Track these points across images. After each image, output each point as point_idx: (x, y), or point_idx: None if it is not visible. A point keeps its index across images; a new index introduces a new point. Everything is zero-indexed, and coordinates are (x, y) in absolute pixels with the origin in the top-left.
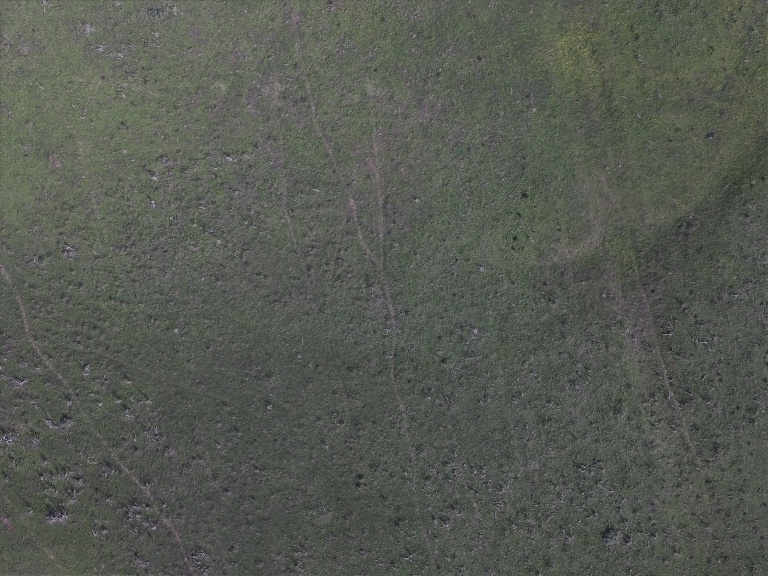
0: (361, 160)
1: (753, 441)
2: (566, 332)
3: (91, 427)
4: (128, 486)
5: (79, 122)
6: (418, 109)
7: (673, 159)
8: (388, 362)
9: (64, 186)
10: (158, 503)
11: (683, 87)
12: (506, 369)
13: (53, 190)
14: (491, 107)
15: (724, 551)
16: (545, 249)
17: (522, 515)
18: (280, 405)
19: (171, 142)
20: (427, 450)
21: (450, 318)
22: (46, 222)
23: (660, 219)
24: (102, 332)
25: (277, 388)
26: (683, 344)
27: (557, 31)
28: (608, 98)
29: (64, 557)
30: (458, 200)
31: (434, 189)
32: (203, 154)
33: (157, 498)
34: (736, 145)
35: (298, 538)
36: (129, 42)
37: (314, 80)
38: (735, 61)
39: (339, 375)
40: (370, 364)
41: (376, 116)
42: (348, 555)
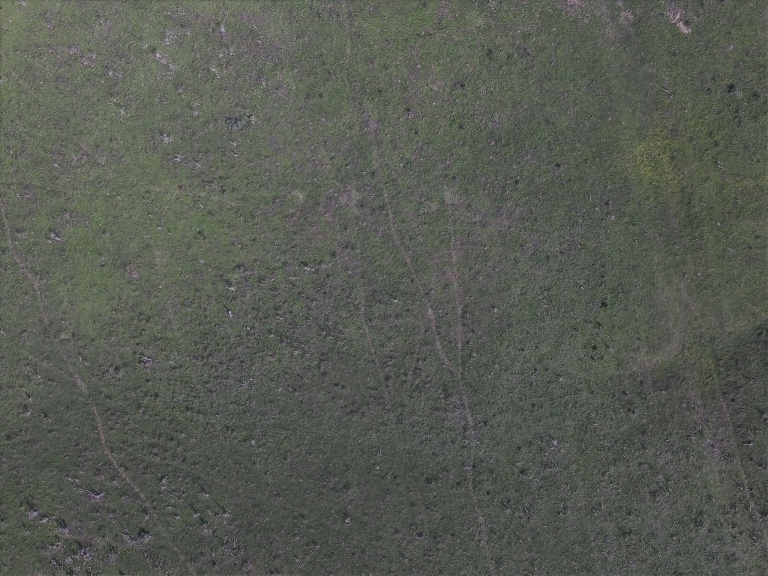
0: (439, 269)
1: None
2: (646, 442)
3: (169, 541)
4: None
5: (156, 232)
6: (496, 217)
7: (753, 266)
8: (467, 473)
9: (141, 296)
10: None
11: (763, 193)
12: (586, 480)
13: (130, 300)
14: (570, 214)
15: None
16: (624, 358)
17: None
18: (358, 517)
19: (248, 251)
20: (507, 563)
21: (529, 428)
22: (123, 332)
23: (740, 327)
24: (179, 443)
25: (355, 500)
26: (764, 454)
27: (635, 137)
28: (687, 205)
29: None
30: (537, 309)
31: (512, 298)
32: (280, 263)
33: None
34: None
35: None
36: (207, 152)
37: (392, 188)
38: None
39: (417, 486)
40: (449, 475)
41: (454, 224)
42: None
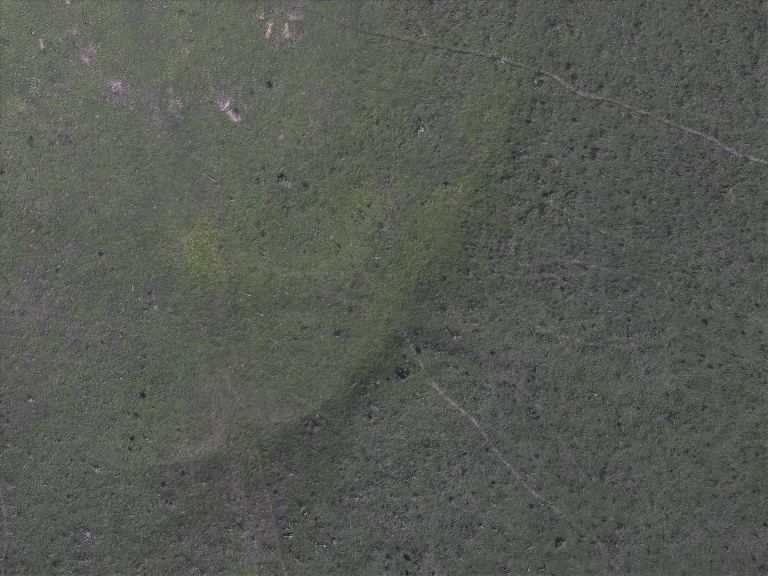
0: None
1: None
2: (182, 535)
3: None
4: None
5: None
6: (35, 306)
7: (299, 357)
8: None
9: None
10: None
11: (310, 284)
12: (119, 572)
13: None
14: (111, 304)
15: None
16: (165, 449)
17: None
18: None
19: None
20: None
21: (63, 520)
22: None
23: (286, 418)
24: None
25: None
26: (302, 547)
27: (183, 226)
28: (233, 295)
29: None
30: (75, 399)
31: (50, 388)
32: None
33: None
34: (365, 343)
35: None
36: None
37: None
38: (364, 258)
39: None
40: None
41: None
42: None
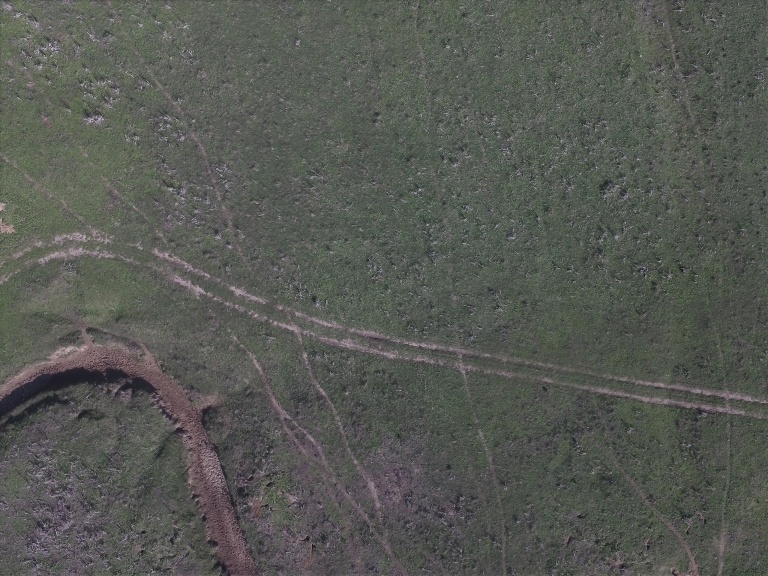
0: None
1: (751, 115)
2: None
3: (131, 45)
4: (161, 100)
5: None
6: None
7: None
8: (412, 12)
9: None
10: (188, 118)
11: None
12: (523, 28)
13: None
14: None
15: (714, 214)
16: None
17: (527, 163)
18: (308, 43)
19: None
20: (442, 96)
21: None
22: None
23: None
24: None
25: (306, 27)
26: (692, 20)
27: None
28: None
29: (97, 156)
30: None
31: None
32: None
33: (187, 114)
34: None
35: (315, 165)
36: None
37: None
38: None
39: (365, 21)
40: (395, 13)
41: None
42: (361, 185)
